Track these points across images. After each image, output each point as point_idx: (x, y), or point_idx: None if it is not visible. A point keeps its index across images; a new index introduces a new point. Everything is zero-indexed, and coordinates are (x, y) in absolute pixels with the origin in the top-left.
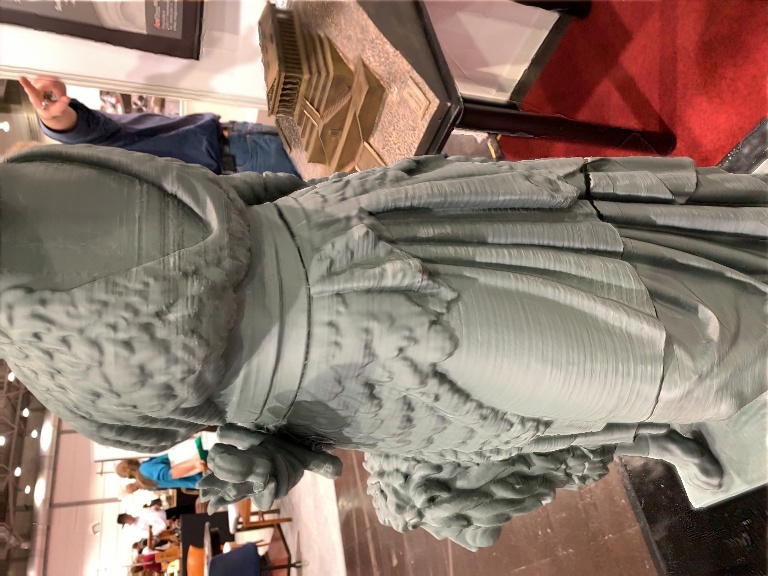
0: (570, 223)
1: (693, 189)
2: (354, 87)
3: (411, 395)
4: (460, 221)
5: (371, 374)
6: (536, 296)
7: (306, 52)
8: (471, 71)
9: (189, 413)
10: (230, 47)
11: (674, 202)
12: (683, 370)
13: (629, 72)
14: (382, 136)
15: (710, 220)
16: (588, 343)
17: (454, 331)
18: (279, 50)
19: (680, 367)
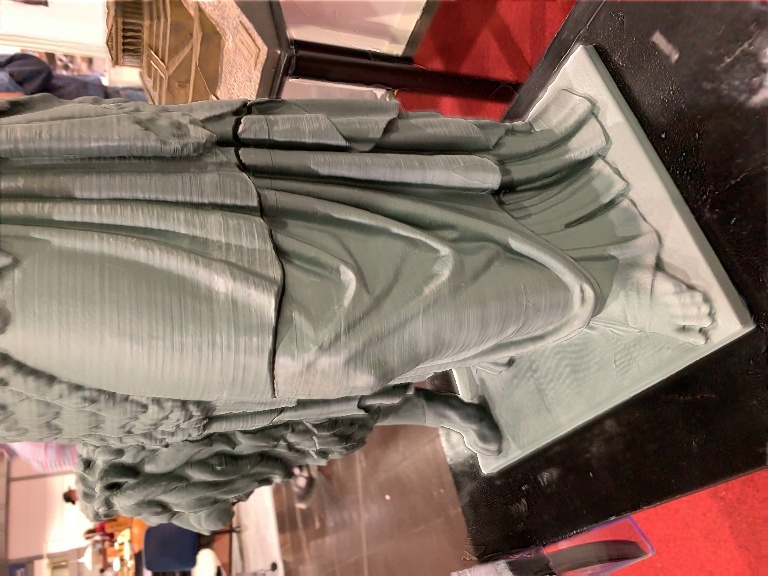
0: (192, 174)
1: (379, 135)
2: (194, 34)
3: None
4: (44, 172)
5: None
6: (125, 260)
7: None
8: (360, 21)
9: None
10: None
11: (351, 149)
12: (301, 340)
13: (505, 21)
14: (227, 88)
15: (388, 169)
16: (178, 313)
17: (4, 303)
18: None
19: (298, 337)
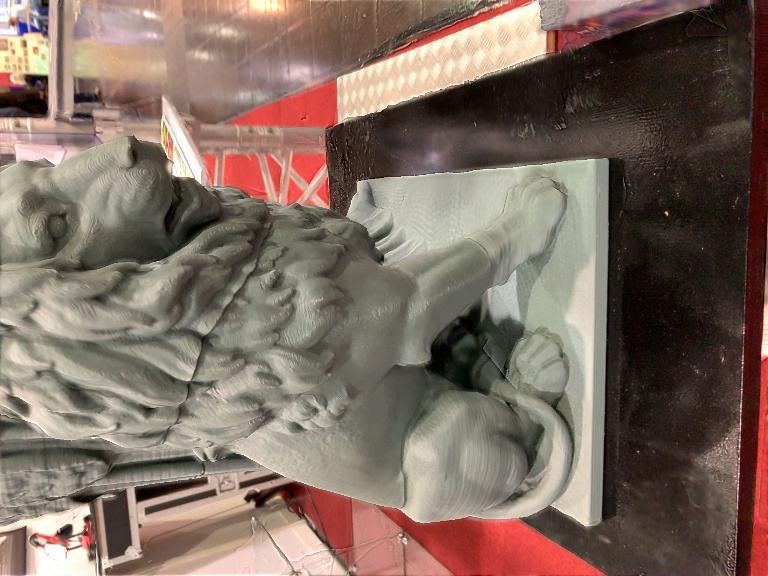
0: None
1: None
2: None
3: None
4: None
5: None
6: None
7: None
8: None
9: None
10: None
11: None
12: None
13: None
14: None
15: None
16: None
17: None
18: None
19: None
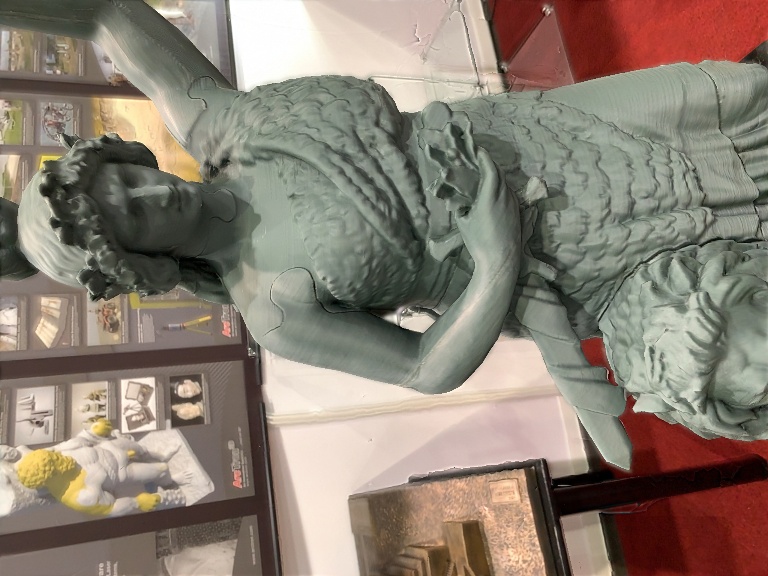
0: None
1: None
2: (451, 552)
3: (542, 119)
4: None
5: (501, 109)
6: None
7: None
8: None
9: (389, 136)
10: None
11: None
12: None
13: (677, 468)
14: (502, 572)
15: None
16: None
17: None
18: None
19: None
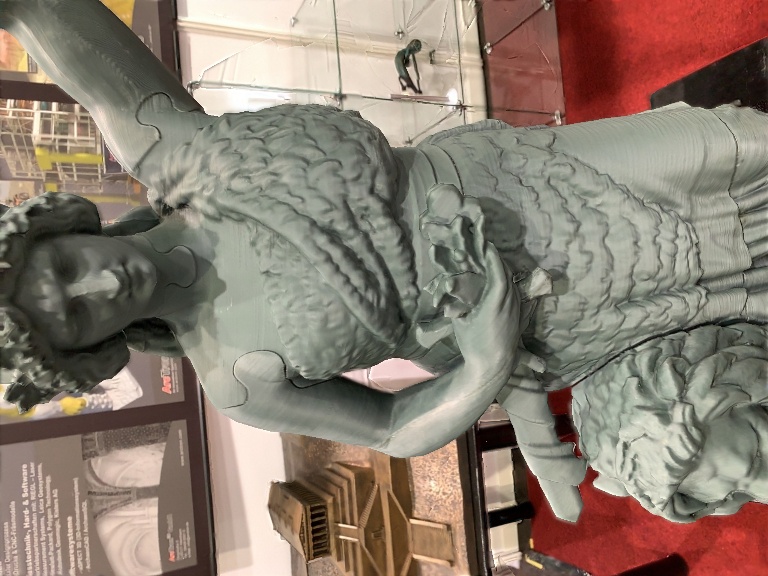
0: None
1: None
2: (377, 476)
3: (552, 178)
4: None
5: (509, 161)
6: None
7: (321, 489)
8: None
9: (384, 205)
10: (244, 564)
11: None
12: None
13: None
14: (423, 499)
15: None
16: None
17: None
18: (296, 497)
19: (714, 110)
